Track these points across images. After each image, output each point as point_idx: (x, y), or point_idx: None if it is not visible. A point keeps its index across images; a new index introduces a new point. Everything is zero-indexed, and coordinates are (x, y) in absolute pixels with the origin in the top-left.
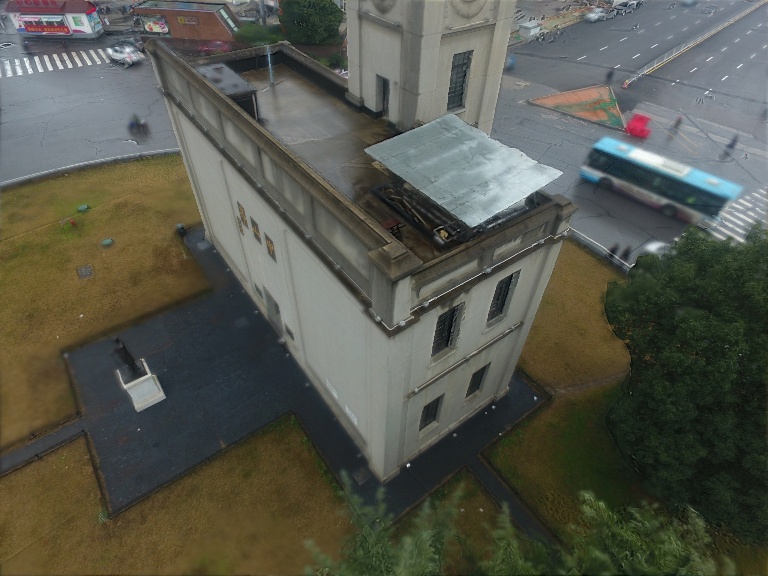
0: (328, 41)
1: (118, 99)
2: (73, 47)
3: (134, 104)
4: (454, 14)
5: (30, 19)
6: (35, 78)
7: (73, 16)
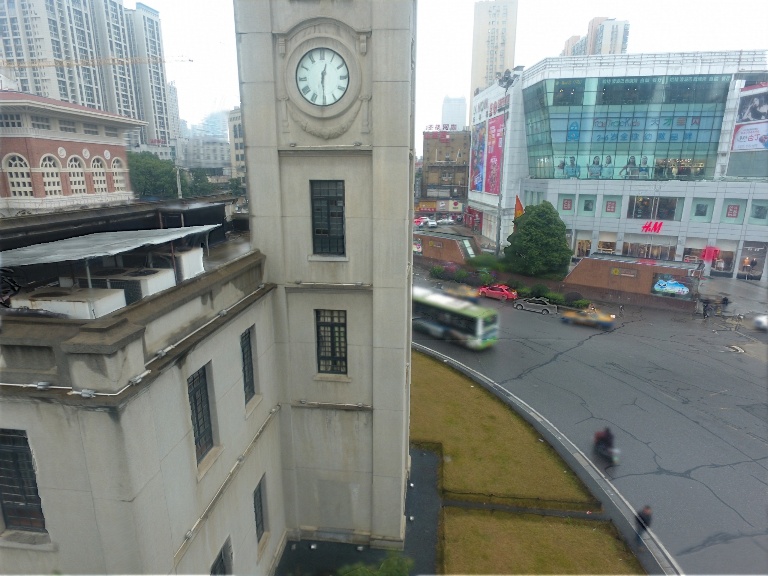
0: (548, 275)
1: None
2: None
3: None
4: (300, 131)
5: None
6: None
7: None
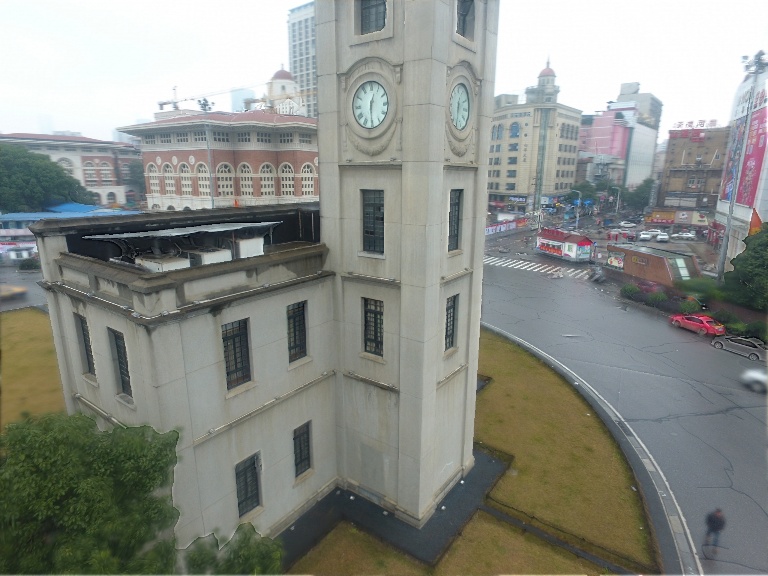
0: None
1: (512, 289)
2: (553, 263)
3: (513, 294)
4: None
5: (543, 241)
6: (498, 268)
7: (569, 244)
